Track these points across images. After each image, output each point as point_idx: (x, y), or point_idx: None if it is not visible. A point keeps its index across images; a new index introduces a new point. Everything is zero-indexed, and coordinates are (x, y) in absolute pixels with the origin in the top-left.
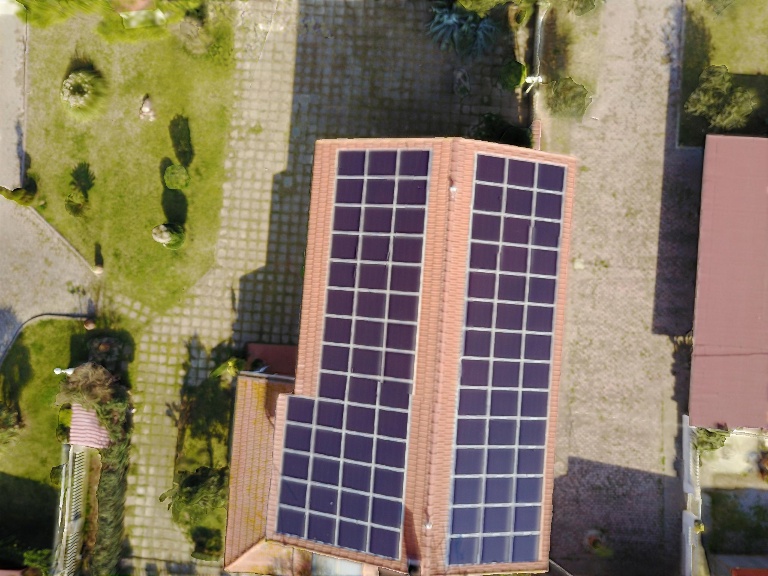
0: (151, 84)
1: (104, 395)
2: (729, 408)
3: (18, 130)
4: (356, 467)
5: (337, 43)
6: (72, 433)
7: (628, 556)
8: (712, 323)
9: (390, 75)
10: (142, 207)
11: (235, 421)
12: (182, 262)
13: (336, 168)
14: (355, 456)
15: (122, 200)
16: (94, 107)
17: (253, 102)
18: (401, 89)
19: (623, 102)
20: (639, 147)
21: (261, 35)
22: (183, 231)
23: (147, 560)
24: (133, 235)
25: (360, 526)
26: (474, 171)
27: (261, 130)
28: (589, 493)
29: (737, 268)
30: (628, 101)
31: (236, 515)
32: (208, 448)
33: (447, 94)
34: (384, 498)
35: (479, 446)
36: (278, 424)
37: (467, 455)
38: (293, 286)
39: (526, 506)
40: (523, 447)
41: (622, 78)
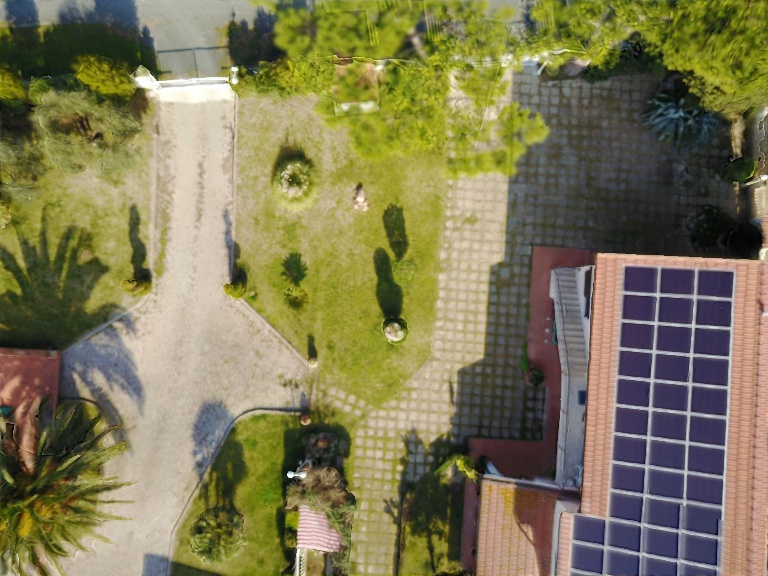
0: (364, 173)
1: (337, 498)
2: None
3: (226, 219)
4: None
5: (553, 133)
6: (299, 536)
7: None
8: None
9: (607, 165)
10: (356, 298)
11: (479, 526)
12: (398, 354)
13: (623, 284)
14: None
15: (335, 291)
16: (309, 197)
17: (469, 192)
18: (618, 179)
19: None
20: None
21: (475, 124)
22: None
23: None
24: (347, 327)
25: None
26: None
27: (477, 220)
28: None
29: None
30: None
31: None
32: (428, 545)
33: (664, 185)
34: None
35: None
36: (562, 543)
37: None
38: (512, 379)
39: None
40: None
41: None
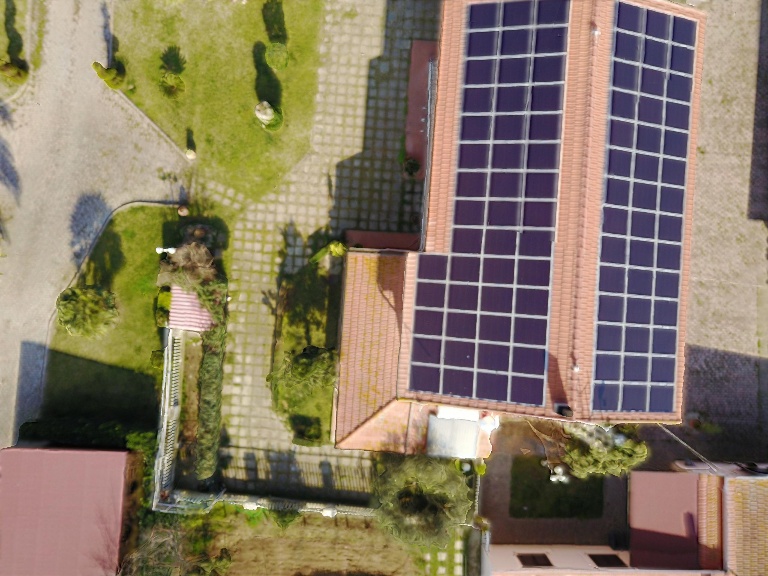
0: None
1: (207, 275)
2: None
3: (105, 12)
4: (494, 319)
5: None
6: (171, 317)
7: (725, 436)
8: None
9: None
10: (235, 92)
11: (345, 298)
12: (277, 148)
13: (468, 22)
14: (493, 308)
15: (214, 85)
16: None
17: None
18: None
19: None
20: (735, 34)
21: None
22: None
23: (245, 449)
24: (226, 120)
25: (500, 376)
26: (616, 18)
27: (357, 14)
28: (686, 376)
29: None
30: None
31: (348, 391)
32: (305, 336)
33: None
34: (525, 347)
35: (619, 294)
36: (408, 283)
37: (608, 302)
38: (391, 172)
39: (661, 357)
40: (658, 298)
41: None
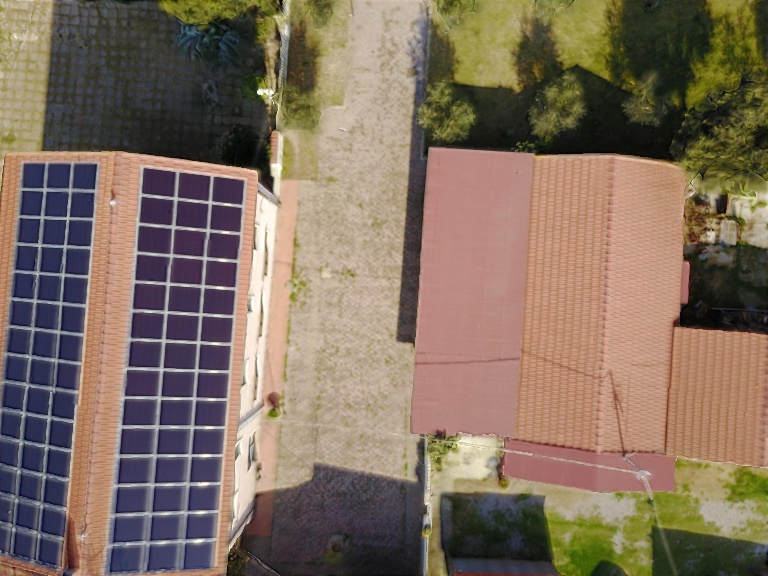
0: None
1: None
2: (449, 415)
3: None
4: (31, 476)
5: (91, 53)
6: None
7: (370, 560)
8: (433, 331)
9: (142, 85)
10: None
11: None
12: None
13: (21, 180)
14: (30, 465)
15: None
16: None
17: (6, 111)
18: (154, 99)
19: (370, 114)
20: (385, 158)
21: (15, 45)
22: None
23: None
24: None
25: (31, 535)
26: (140, 185)
27: (14, 139)
28: (334, 498)
29: (458, 278)
30: (375, 113)
31: None
32: None
33: (199, 105)
34: (52, 507)
35: (146, 455)
36: None
37: (133, 464)
38: None
39: (200, 513)
40: (198, 456)
41: (369, 90)
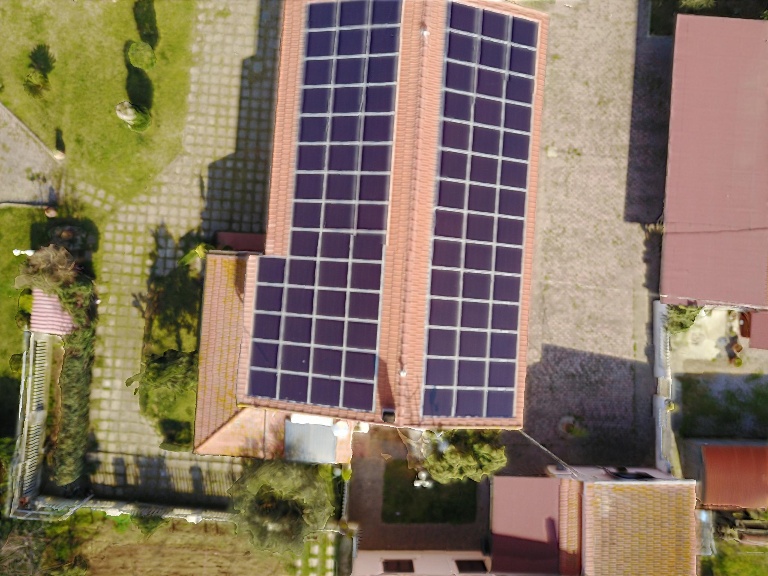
0: None
1: (66, 278)
2: (699, 285)
3: None
4: (329, 323)
5: None
6: (33, 320)
7: (600, 441)
8: (682, 201)
9: None
10: (106, 92)
11: (204, 301)
12: (148, 149)
13: (307, 21)
14: (328, 312)
15: (84, 84)
16: None
17: None
18: None
19: None
20: (612, 35)
21: None
22: (149, 113)
23: (113, 454)
24: (96, 120)
25: (333, 381)
26: (448, 18)
27: (230, 13)
28: (562, 380)
29: (707, 147)
30: None
31: (205, 396)
32: (176, 339)
33: None
34: (357, 351)
35: (453, 298)
36: (248, 286)
37: (441, 306)
38: (264, 174)
39: (500, 361)
40: (497, 302)
41: None
